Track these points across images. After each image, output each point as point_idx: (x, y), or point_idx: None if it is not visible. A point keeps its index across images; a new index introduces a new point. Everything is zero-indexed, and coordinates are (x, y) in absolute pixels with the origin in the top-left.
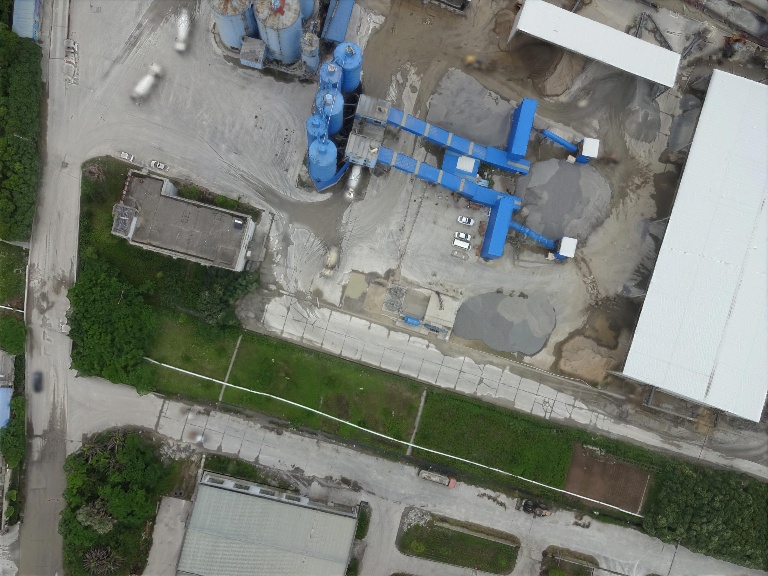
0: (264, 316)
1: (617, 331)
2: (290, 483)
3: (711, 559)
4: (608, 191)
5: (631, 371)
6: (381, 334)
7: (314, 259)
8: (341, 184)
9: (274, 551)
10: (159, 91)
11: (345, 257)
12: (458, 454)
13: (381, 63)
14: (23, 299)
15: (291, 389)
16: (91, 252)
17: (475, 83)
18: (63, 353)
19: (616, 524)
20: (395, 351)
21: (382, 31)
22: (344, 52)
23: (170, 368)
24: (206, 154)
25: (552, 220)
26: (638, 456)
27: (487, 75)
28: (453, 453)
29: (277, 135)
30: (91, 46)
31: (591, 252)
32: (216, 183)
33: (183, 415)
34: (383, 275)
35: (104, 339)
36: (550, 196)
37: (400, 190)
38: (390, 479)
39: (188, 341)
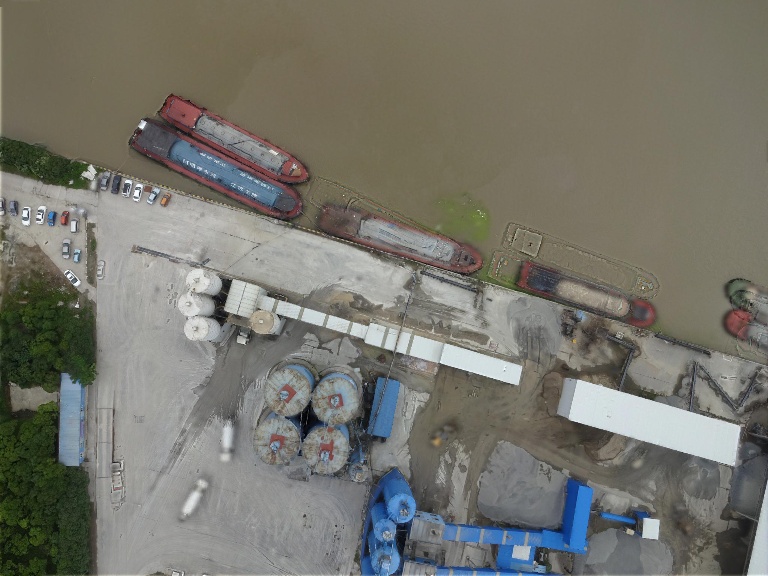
0: None
1: None
2: None
3: None
4: (670, 559)
5: None
6: None
7: None
8: None
9: None
10: (206, 499)
11: None
12: None
13: (428, 444)
14: None
15: None
16: None
17: (526, 457)
18: None
19: None
20: None
21: (427, 409)
22: (397, 508)
23: None
24: (256, 560)
25: None
26: None
27: (537, 444)
28: None
29: (327, 533)
30: (136, 459)
31: None
32: None
33: None
34: None
35: None
36: None
37: None
38: None
39: None
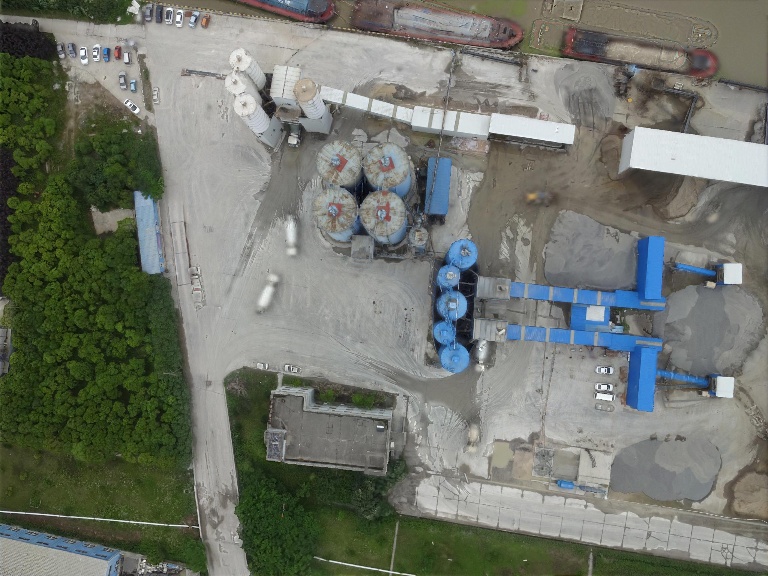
0: (416, 499)
1: None
2: None
3: None
4: (758, 310)
5: None
6: (535, 501)
7: (455, 435)
8: (469, 354)
9: None
10: (279, 295)
11: (485, 428)
12: None
13: (488, 222)
14: (196, 517)
15: (455, 570)
16: (248, 467)
17: (590, 222)
18: (239, 562)
19: None
20: (553, 516)
21: (483, 188)
22: (459, 252)
23: (337, 564)
24: (333, 348)
25: (700, 356)
26: None
27: (601, 210)
28: None
29: (397, 317)
30: (211, 265)
31: (749, 379)
32: (348, 375)
33: None
34: (527, 440)
35: (275, 552)
36: (694, 330)
37: (530, 350)
38: None
39: (349, 535)
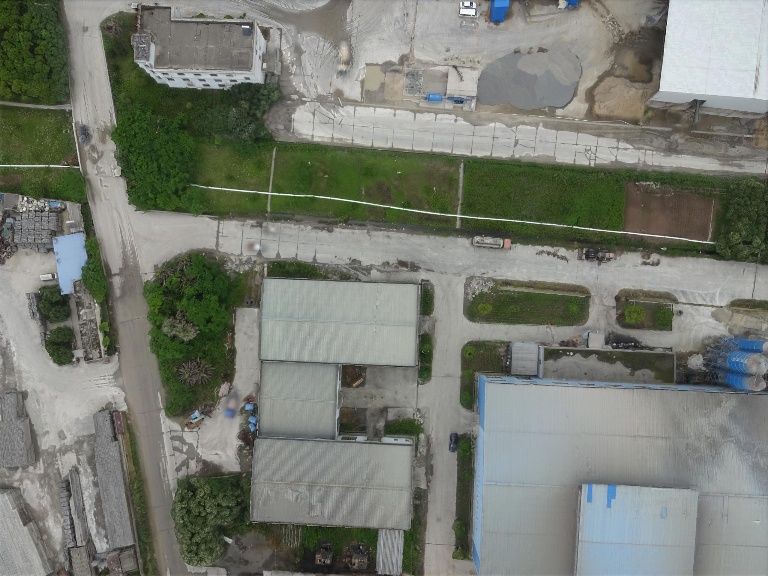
0: (292, 126)
1: (649, 64)
2: (350, 275)
3: None
4: None
5: (668, 86)
6: (407, 118)
7: (328, 62)
8: None
9: (345, 326)
10: None
11: (357, 53)
12: (507, 215)
13: None
14: (76, 155)
15: (332, 186)
16: (124, 96)
17: None
18: (121, 195)
19: (687, 255)
20: (424, 132)
21: None
22: None
23: (217, 189)
24: None
25: None
26: (697, 183)
27: None
28: (502, 216)
29: None
30: None
31: None
32: (222, 13)
33: (238, 231)
34: (397, 62)
35: (151, 167)
36: None
37: None
38: (445, 254)
39: (228, 162)
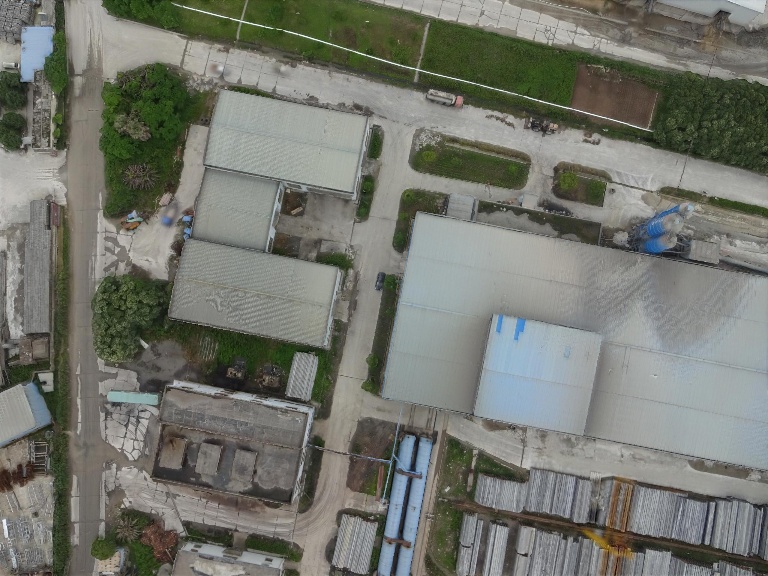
0: None
1: None
2: None
3: (728, 172)
4: None
5: None
6: None
7: None
8: None
9: (291, 144)
10: None
11: None
12: (463, 76)
13: None
14: None
15: (301, 23)
16: None
17: None
18: (96, 0)
19: (626, 138)
20: None
21: None
22: None
23: (191, 10)
24: None
25: None
26: (644, 74)
27: None
28: (459, 75)
29: None
30: None
31: None
32: None
33: (205, 53)
34: None
35: None
36: None
37: None
38: (400, 104)
39: None
